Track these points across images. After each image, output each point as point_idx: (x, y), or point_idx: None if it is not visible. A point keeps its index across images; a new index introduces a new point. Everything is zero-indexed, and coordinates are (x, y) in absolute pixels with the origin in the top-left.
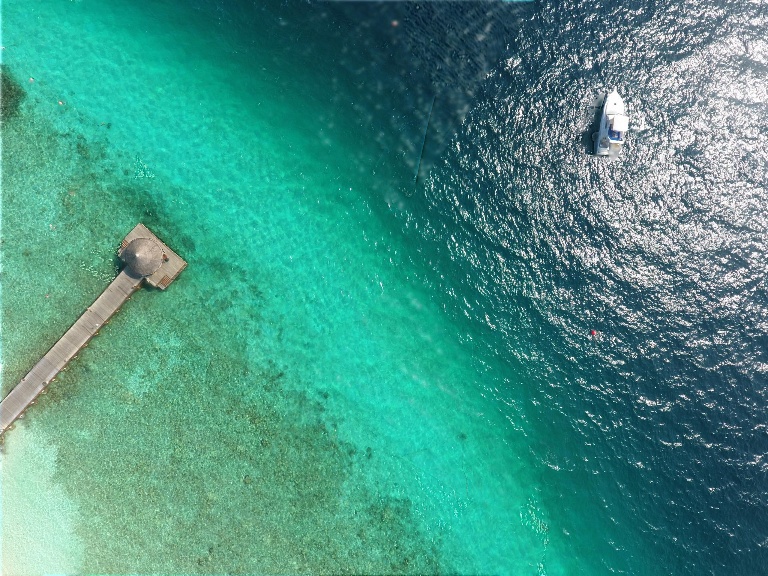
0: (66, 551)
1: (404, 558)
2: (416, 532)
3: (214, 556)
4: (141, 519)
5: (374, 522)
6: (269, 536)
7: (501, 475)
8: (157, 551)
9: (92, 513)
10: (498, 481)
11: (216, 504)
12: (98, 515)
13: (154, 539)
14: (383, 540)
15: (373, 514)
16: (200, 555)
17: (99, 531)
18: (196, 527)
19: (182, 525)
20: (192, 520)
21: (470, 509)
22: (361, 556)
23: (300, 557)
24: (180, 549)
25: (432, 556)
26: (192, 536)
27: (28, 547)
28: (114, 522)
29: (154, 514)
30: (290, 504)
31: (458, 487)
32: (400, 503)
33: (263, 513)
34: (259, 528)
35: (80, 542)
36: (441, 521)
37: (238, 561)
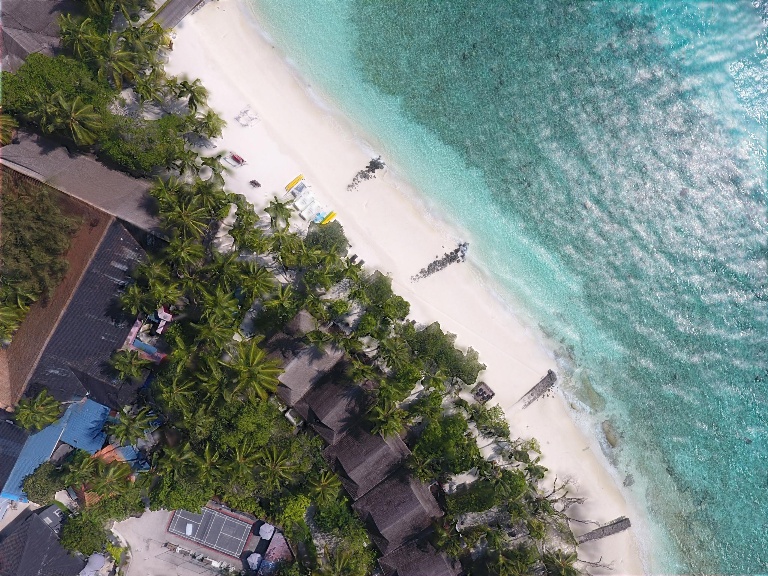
0: (342, 36)
1: (652, 69)
2: (662, 48)
3: (478, 51)
4: (411, 12)
5: (624, 33)
6: (528, 37)
7: (739, 4)
8: (425, 42)
9: (366, 3)
10: (737, 8)
11: (479, 5)
12: (372, 5)
13: (423, 31)
14: (632, 50)
15: (623, 26)
16: (465, 50)
17: (373, 20)
18: (461, 23)
19: (448, 20)
20: (457, 17)
21: (713, 28)
22: (612, 63)
23: (556, 60)
24: (446, 43)
25: (676, 72)
26: (458, 31)
27: (308, 29)
28: (386, 13)
29: (423, 8)
30: (547, 10)
31: (703, 4)
32: (648, 18)
33: (522, 16)
34: (519, 29)
35: (355, 29)
36: (684, 41)
37: (499, 58)
